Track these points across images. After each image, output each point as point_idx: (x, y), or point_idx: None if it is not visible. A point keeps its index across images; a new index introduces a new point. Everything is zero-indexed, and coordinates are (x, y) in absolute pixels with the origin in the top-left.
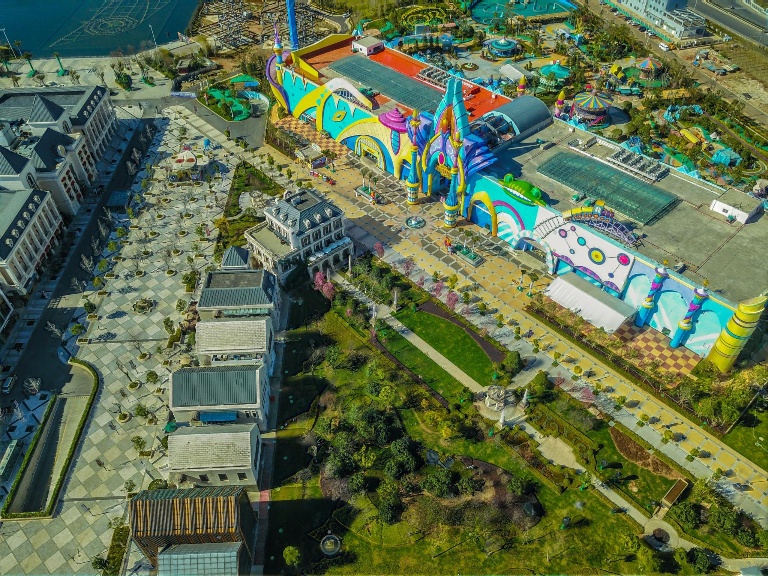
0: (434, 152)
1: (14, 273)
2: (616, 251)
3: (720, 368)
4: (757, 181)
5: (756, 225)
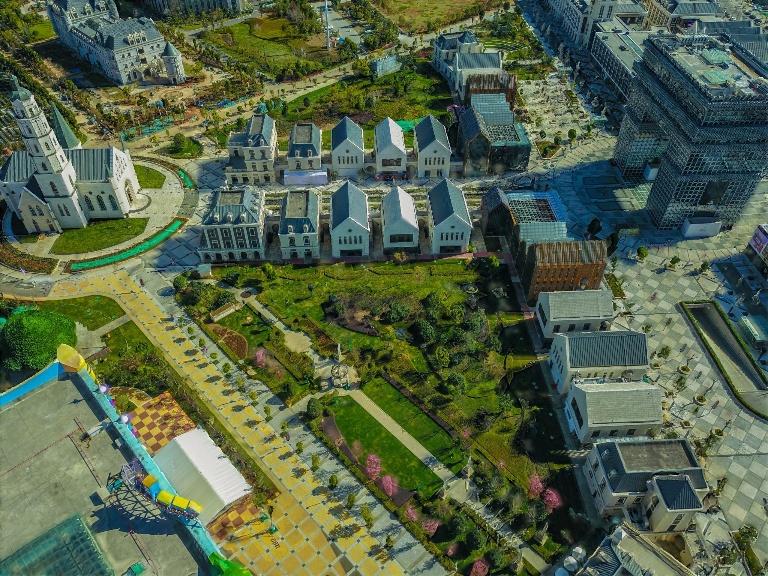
0: None
1: None
2: None
3: None
4: None
5: None
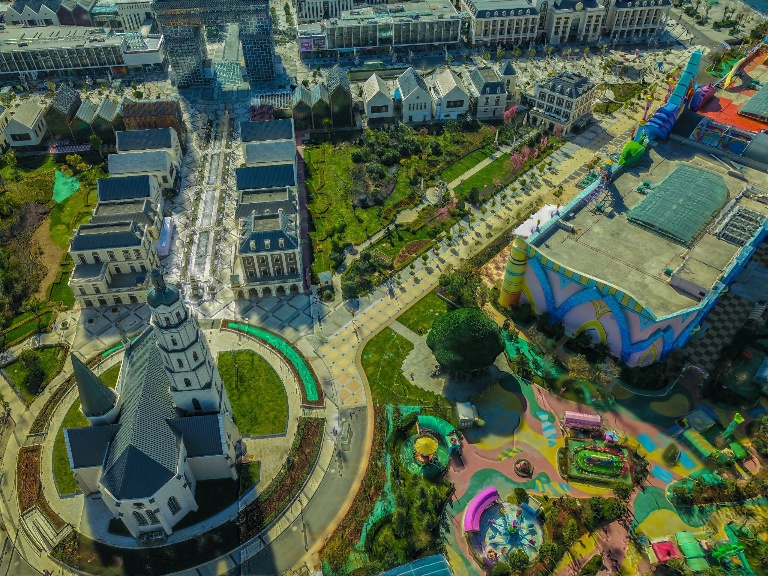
0: None
1: (480, 32)
2: None
3: None
4: None
5: (672, 292)
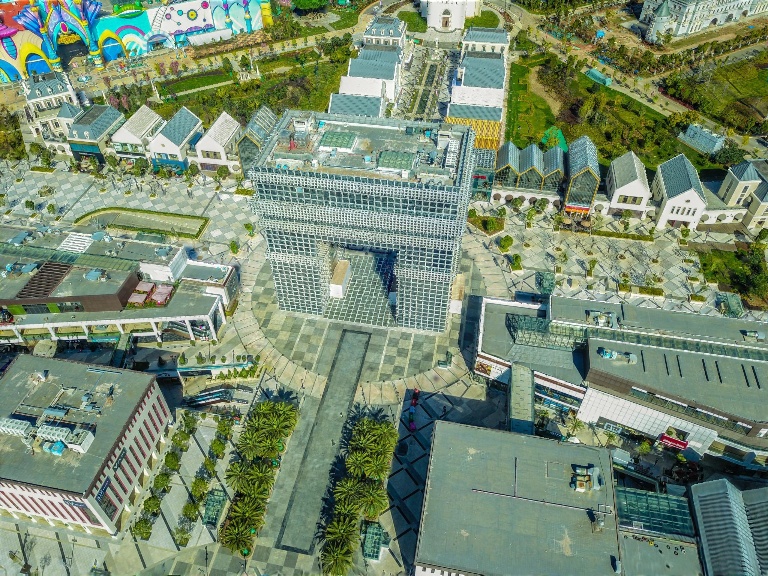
0: (54, 27)
1: None
2: (199, 3)
3: None
4: None
5: None
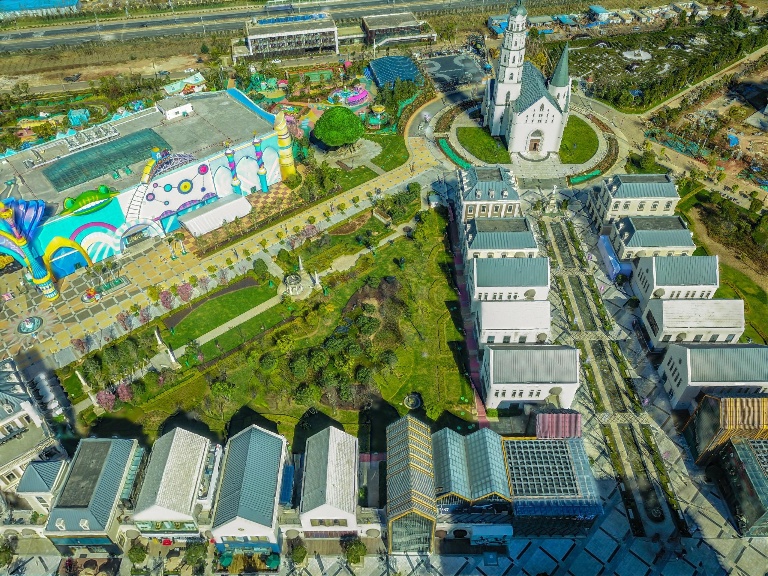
0: None
1: None
2: (194, 169)
3: (294, 174)
4: (119, 111)
5: (196, 107)
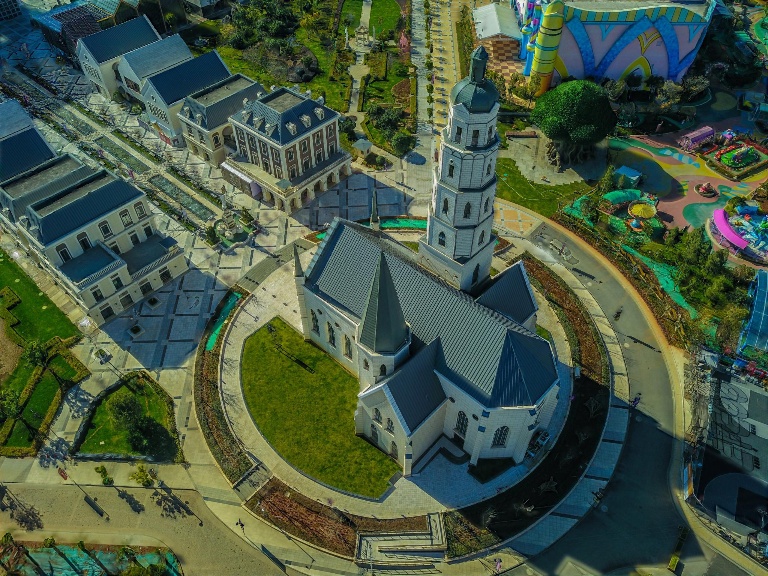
0: None
1: None
2: None
3: None
4: None
5: None
